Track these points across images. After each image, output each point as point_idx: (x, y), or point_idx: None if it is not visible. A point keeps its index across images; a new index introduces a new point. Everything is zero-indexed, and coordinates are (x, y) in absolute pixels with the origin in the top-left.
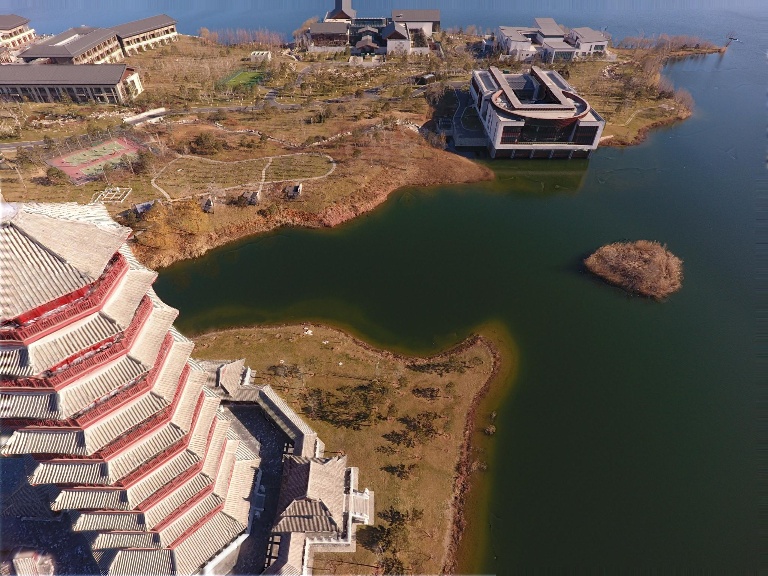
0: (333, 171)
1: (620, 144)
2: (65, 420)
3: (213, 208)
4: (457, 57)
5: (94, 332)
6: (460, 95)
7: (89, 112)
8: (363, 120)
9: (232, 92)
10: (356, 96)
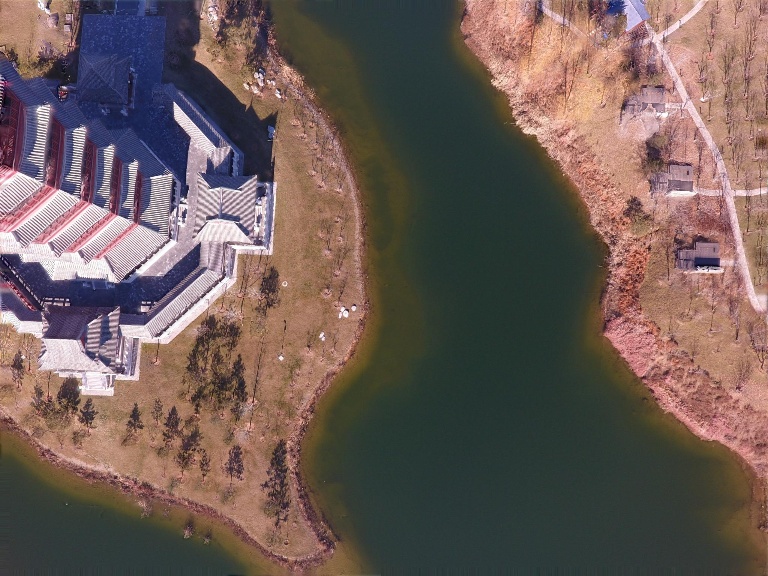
0: None
1: None
2: None
3: None
4: None
5: None
6: None
7: None
8: None
9: None
10: None
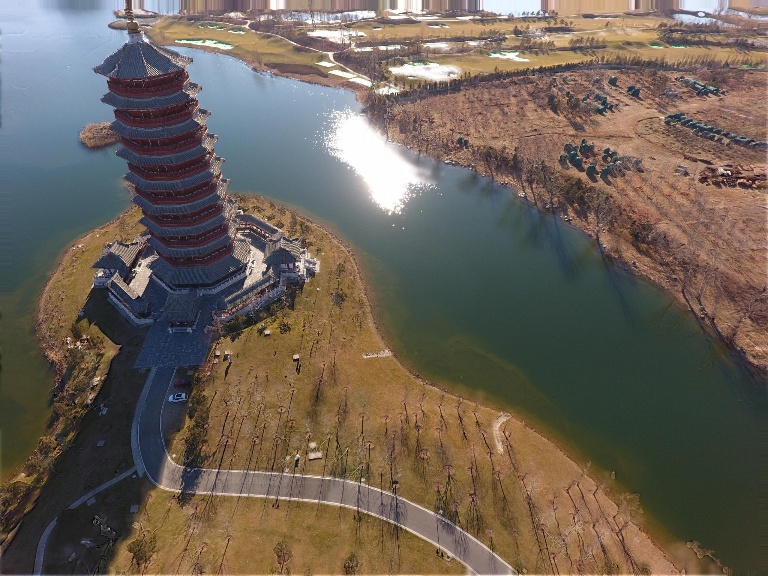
0: None
1: None
2: None
3: None
4: None
5: None
6: None
7: None
8: None
9: None
10: None
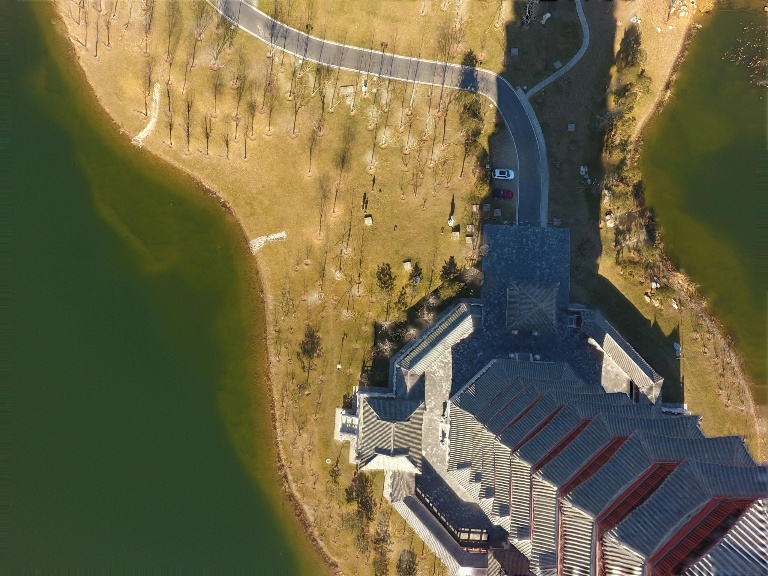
0: None
1: None
2: None
3: None
4: None
5: None
6: None
7: None
8: None
9: None
10: None
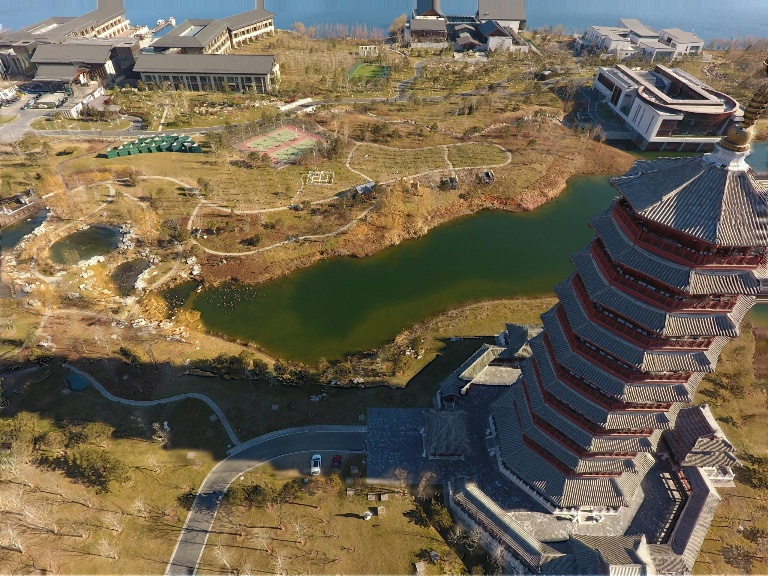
0: (512, 159)
1: (756, 139)
2: (702, 341)
3: (420, 191)
4: (558, 55)
5: (765, 264)
6: (585, 91)
7: (242, 101)
8: (509, 113)
9: (364, 84)
10: (489, 90)
